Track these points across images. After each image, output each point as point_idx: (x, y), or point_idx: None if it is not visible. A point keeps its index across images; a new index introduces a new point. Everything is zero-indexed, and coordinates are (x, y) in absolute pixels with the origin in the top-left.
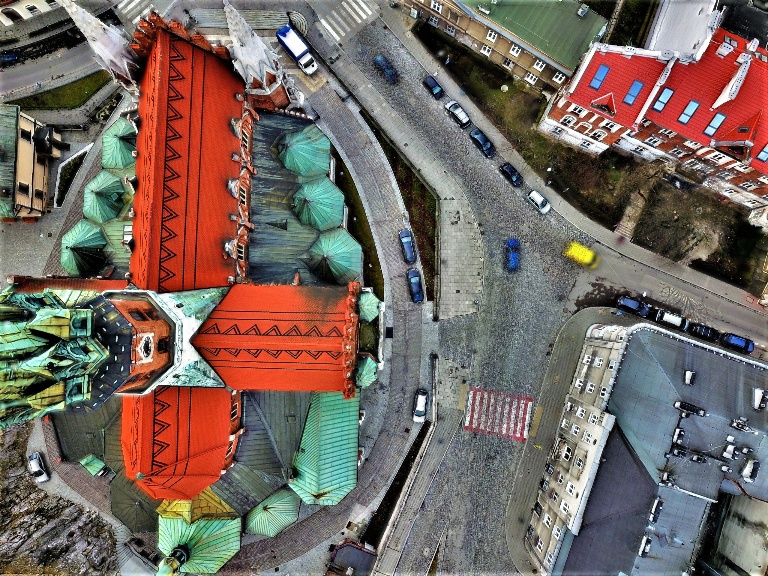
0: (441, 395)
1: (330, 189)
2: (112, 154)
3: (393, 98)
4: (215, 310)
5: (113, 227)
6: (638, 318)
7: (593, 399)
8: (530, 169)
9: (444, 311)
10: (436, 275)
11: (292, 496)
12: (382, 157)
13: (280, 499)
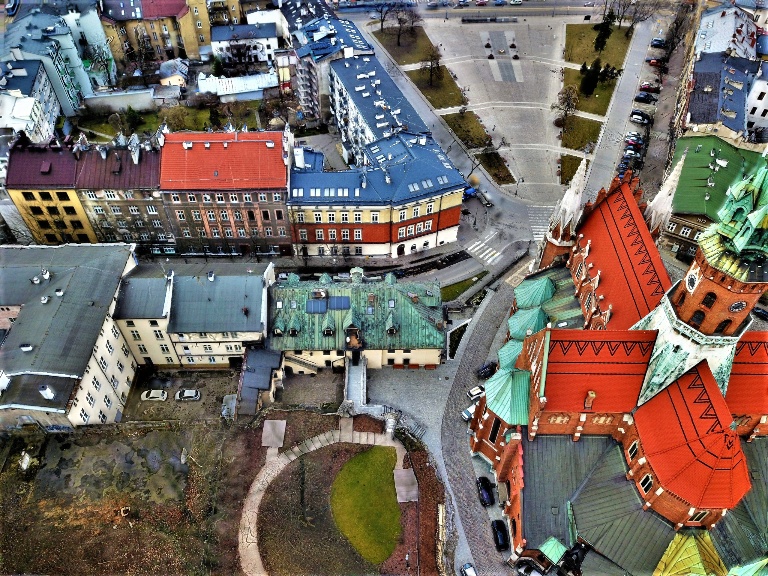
0: None
1: None
2: (531, 296)
3: None
4: None
5: None
6: None
7: None
8: None
9: None
10: None
11: None
12: None
13: (765, 573)
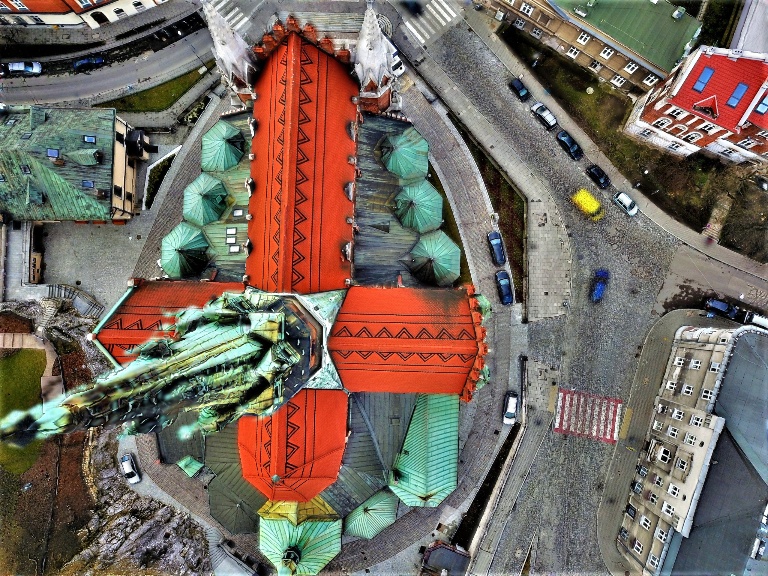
0: (531, 397)
1: (430, 192)
2: (214, 157)
3: (478, 100)
4: (339, 313)
5: (215, 230)
6: (726, 320)
7: (693, 401)
8: (617, 171)
9: (533, 313)
10: (525, 277)
11: (390, 498)
12: (470, 159)
13: (379, 501)
